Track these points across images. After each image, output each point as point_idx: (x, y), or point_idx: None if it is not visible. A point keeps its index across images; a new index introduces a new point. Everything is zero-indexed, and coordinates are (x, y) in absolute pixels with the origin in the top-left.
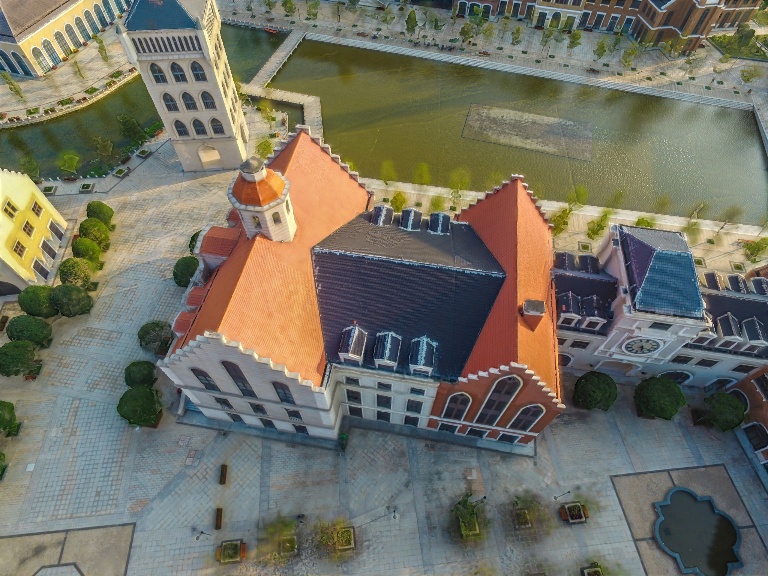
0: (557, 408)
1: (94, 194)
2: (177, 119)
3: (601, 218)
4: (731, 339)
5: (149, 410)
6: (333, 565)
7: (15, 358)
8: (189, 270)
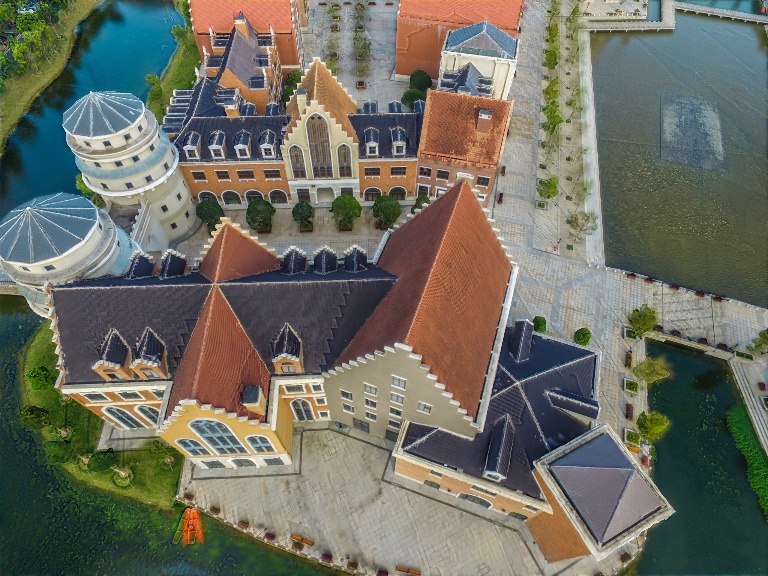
0: None
1: None
2: None
3: None
4: None
5: None
6: (351, 27)
7: None
8: None
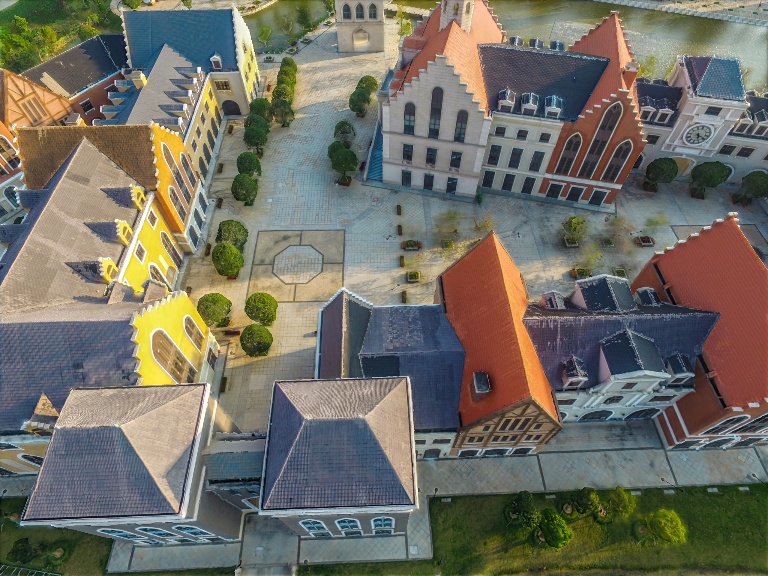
0: (642, 143)
1: (275, 63)
2: (346, 3)
3: (667, 75)
4: (764, 124)
5: (354, 161)
6: None
7: (258, 133)
8: (363, 96)
